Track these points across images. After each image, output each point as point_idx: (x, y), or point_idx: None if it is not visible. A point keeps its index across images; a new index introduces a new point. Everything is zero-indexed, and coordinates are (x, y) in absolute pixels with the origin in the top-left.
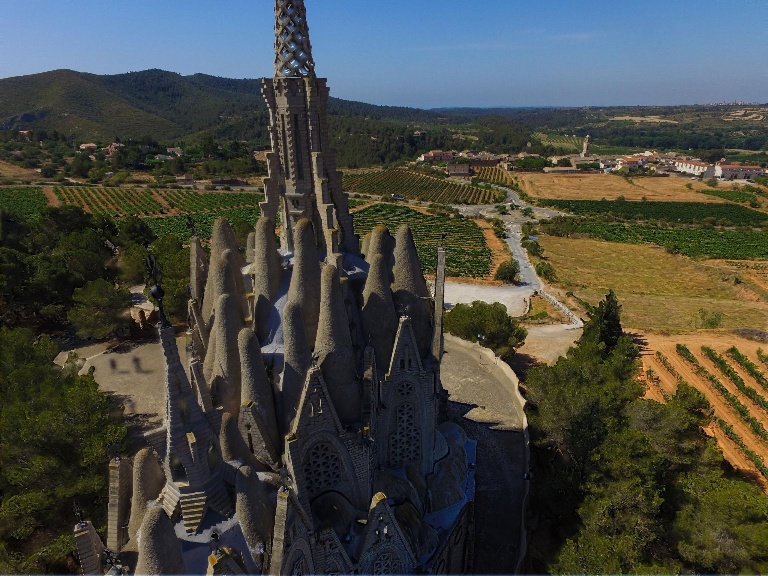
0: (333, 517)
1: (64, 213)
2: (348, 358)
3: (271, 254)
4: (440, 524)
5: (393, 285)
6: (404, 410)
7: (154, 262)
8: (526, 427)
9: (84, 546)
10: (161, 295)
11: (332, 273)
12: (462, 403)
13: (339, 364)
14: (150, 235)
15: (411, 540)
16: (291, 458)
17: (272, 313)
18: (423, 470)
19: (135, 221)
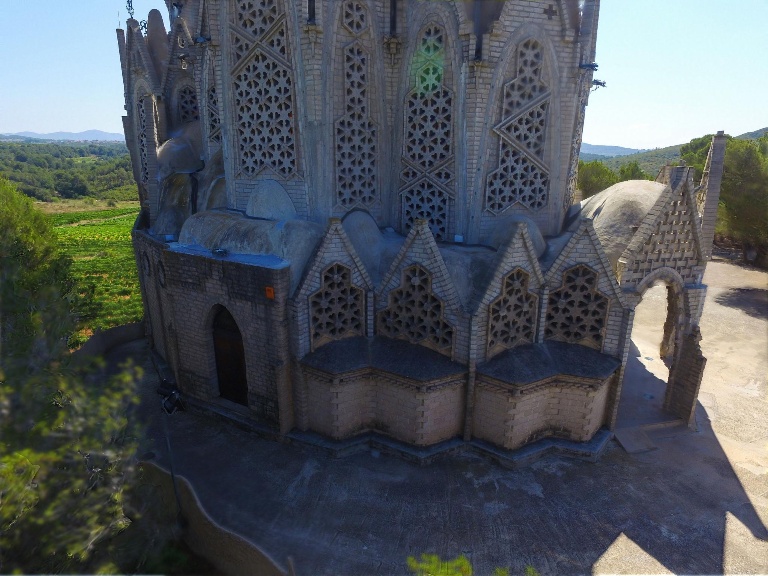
0: None
1: None
2: None
3: None
4: None
5: None
6: None
7: None
8: None
9: None
10: None
11: None
12: (720, 562)
13: None
14: None
15: None
16: None
17: None
18: None
19: None
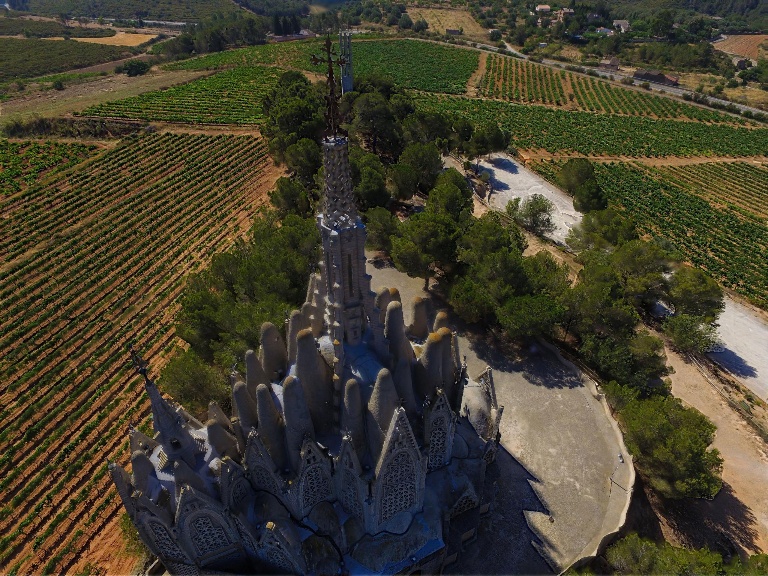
0: (260, 509)
1: (428, 119)
2: (296, 435)
3: (294, 336)
4: (350, 569)
5: (369, 404)
6: (350, 486)
7: (140, 359)
8: (557, 575)
9: (132, 440)
10: (143, 373)
11: (287, 385)
12: (538, 499)
13: (289, 435)
14: (501, 144)
15: (309, 560)
16: (221, 469)
17: (288, 370)
18: (366, 528)
19: (493, 128)
